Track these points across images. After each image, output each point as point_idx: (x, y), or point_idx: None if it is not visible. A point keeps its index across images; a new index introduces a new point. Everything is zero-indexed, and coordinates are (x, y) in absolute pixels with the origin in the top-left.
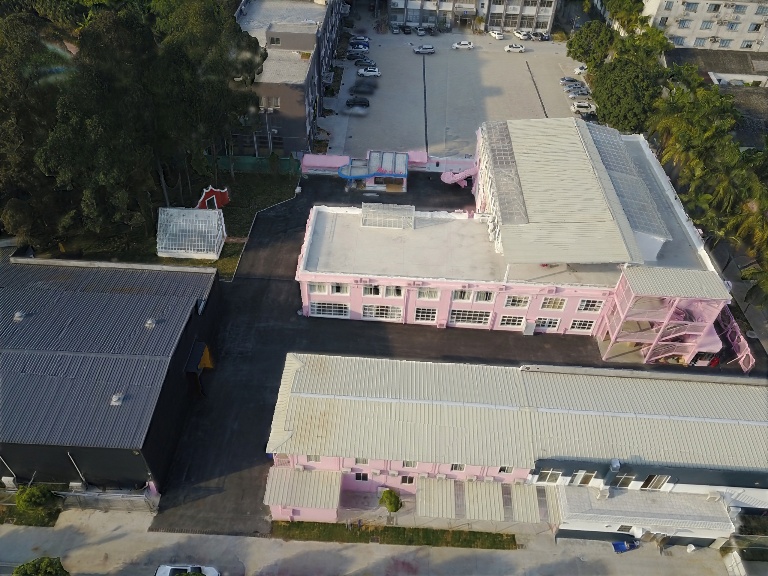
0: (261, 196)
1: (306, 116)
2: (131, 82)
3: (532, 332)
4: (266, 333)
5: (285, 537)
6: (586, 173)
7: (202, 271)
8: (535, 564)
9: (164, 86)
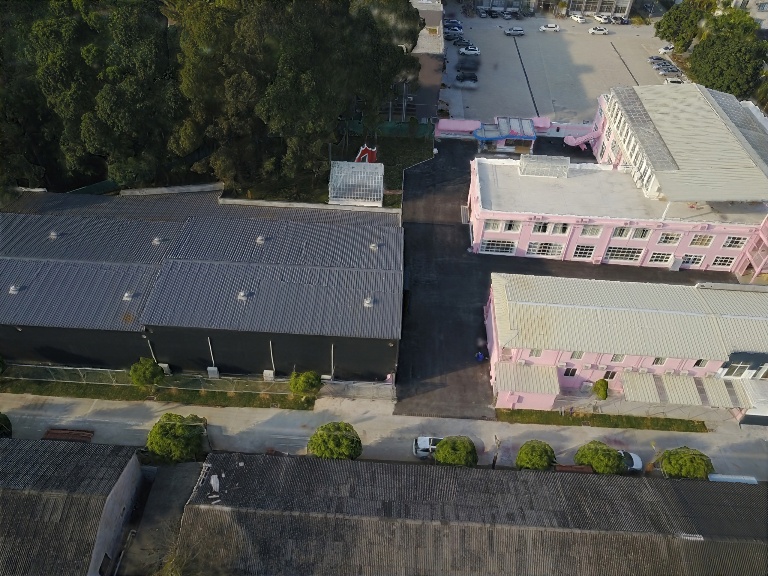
0: (403, 156)
1: (440, 85)
2: (336, 42)
3: (678, 268)
4: (445, 266)
5: (510, 421)
6: (720, 129)
7: (388, 211)
8: (727, 443)
9: (360, 47)
